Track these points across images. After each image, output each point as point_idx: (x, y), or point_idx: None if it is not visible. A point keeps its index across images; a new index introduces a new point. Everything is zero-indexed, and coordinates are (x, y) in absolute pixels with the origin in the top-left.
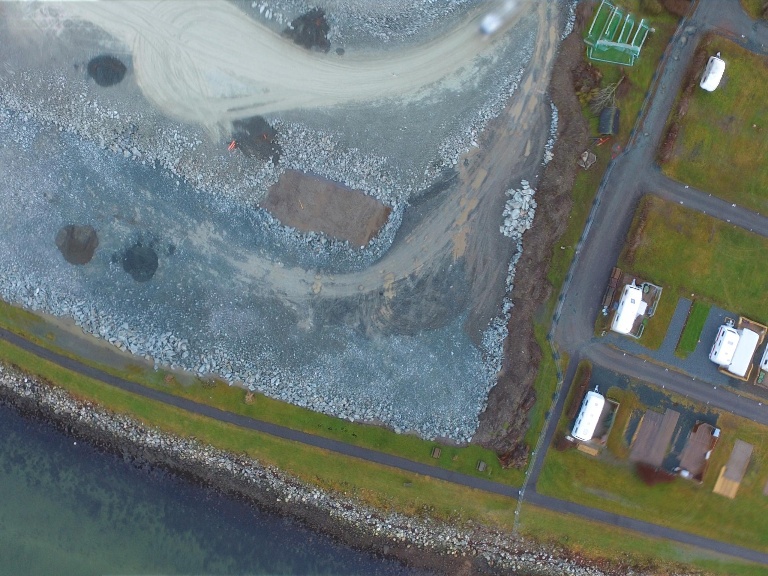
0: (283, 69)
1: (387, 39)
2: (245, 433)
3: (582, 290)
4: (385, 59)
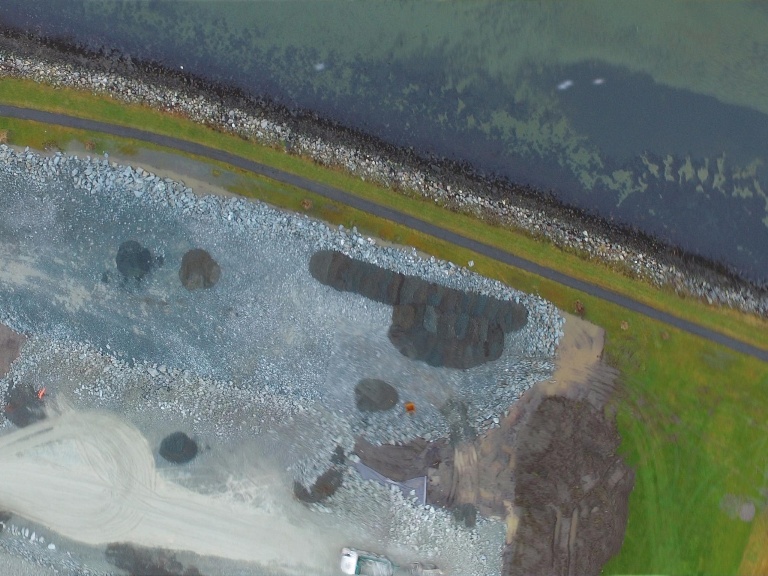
0: (7, 479)
1: None
2: (5, 99)
3: None
4: None
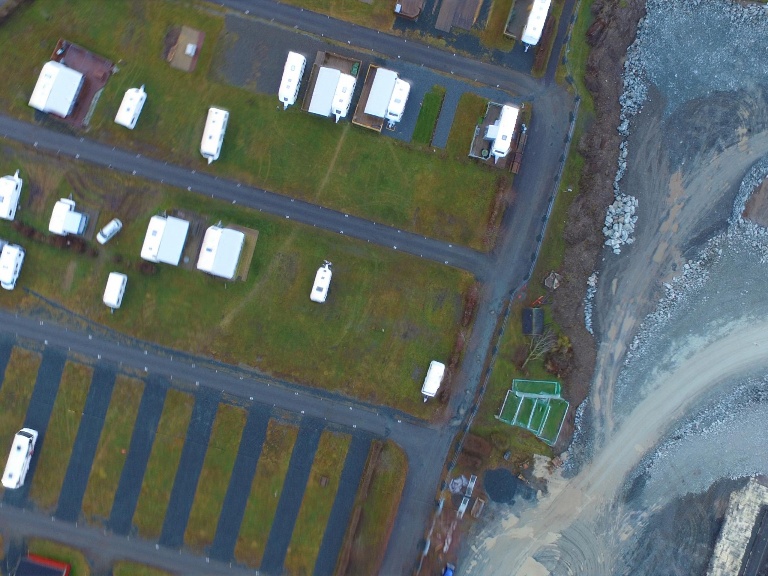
0: None
1: (767, 378)
2: None
3: (548, 149)
4: (767, 358)
